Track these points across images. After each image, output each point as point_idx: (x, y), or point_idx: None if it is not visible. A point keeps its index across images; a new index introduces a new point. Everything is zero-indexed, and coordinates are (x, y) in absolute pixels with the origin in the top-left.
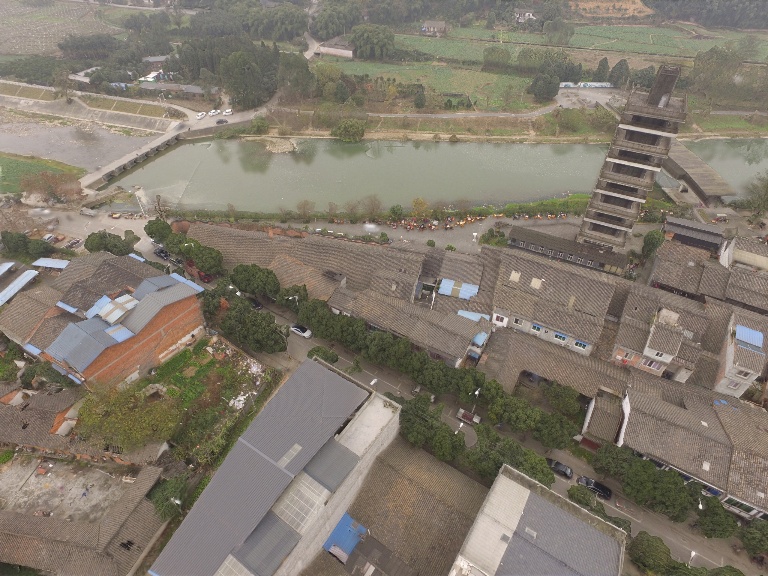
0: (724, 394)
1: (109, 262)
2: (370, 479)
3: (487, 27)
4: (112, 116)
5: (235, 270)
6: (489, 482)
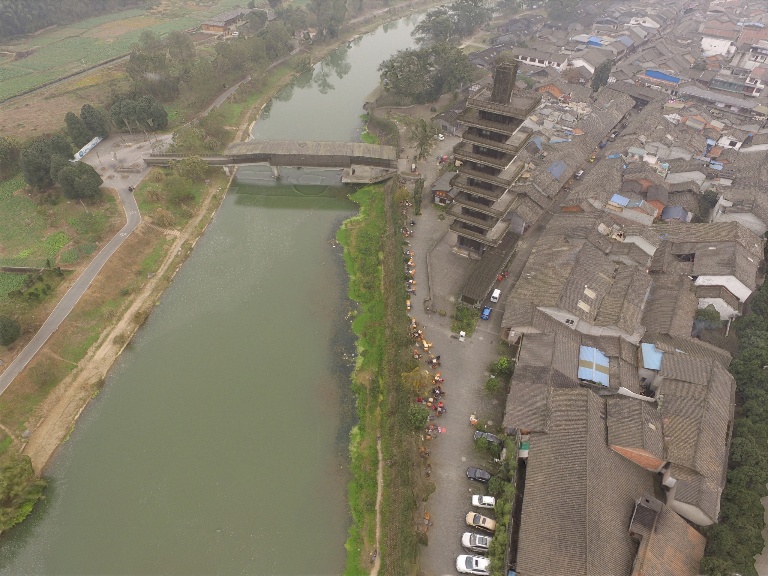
0: None
1: None
2: None
3: None
4: None
5: None
6: None
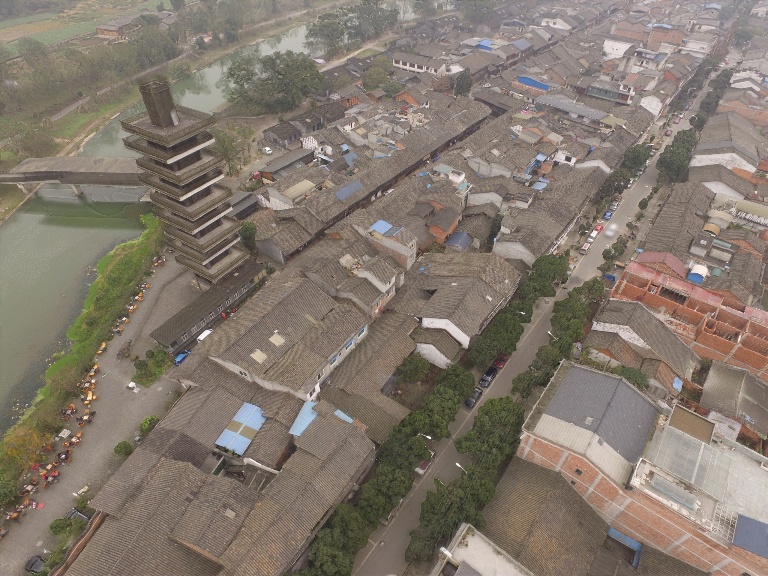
0: (412, 266)
1: None
2: None
3: None
4: None
5: None
6: None
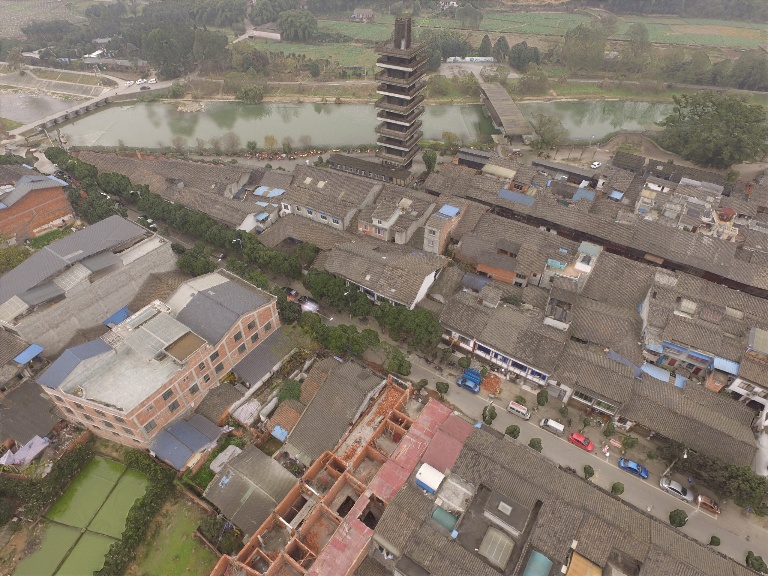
0: None
1: (2, 166)
2: (144, 287)
3: (413, 14)
4: (56, 85)
5: (100, 176)
6: None
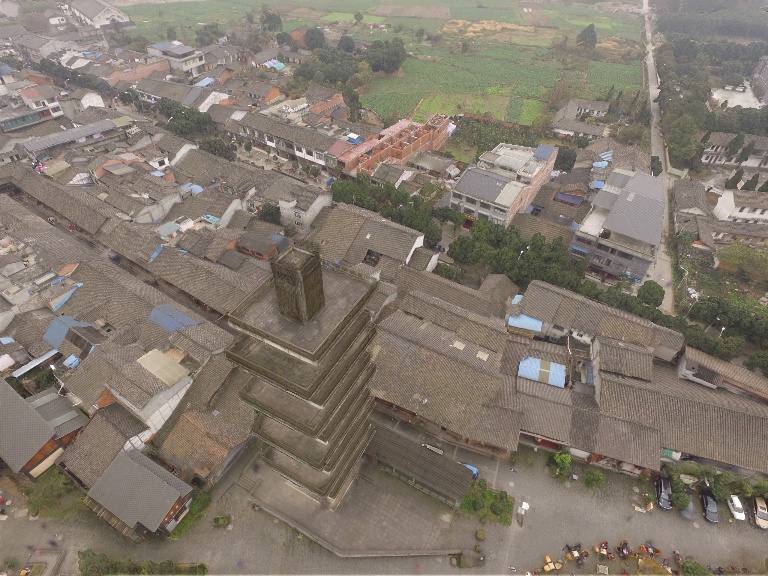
0: None
1: None
2: None
3: None
4: None
5: None
6: None
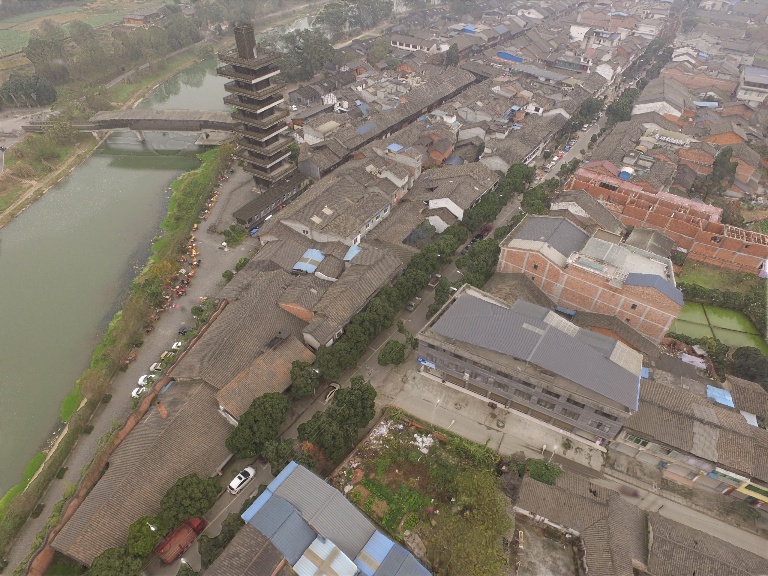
0: (418, 177)
1: None
2: None
3: None
4: None
5: (243, 442)
6: (488, 274)
